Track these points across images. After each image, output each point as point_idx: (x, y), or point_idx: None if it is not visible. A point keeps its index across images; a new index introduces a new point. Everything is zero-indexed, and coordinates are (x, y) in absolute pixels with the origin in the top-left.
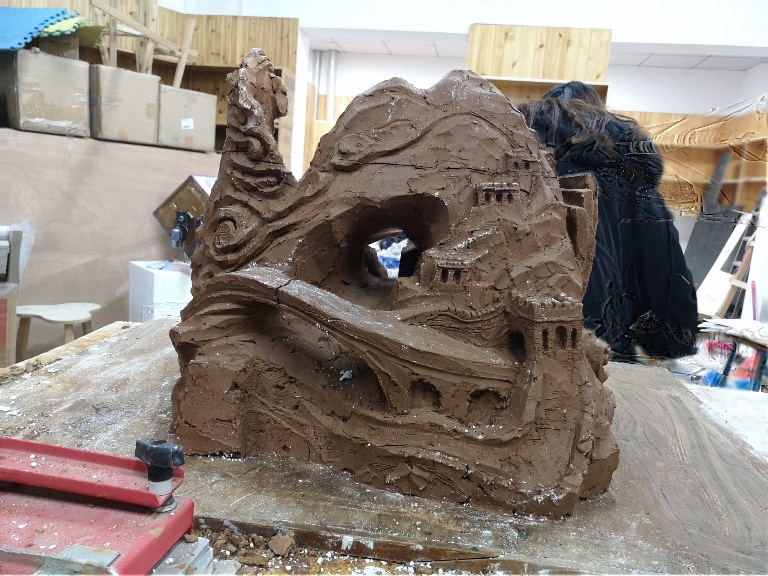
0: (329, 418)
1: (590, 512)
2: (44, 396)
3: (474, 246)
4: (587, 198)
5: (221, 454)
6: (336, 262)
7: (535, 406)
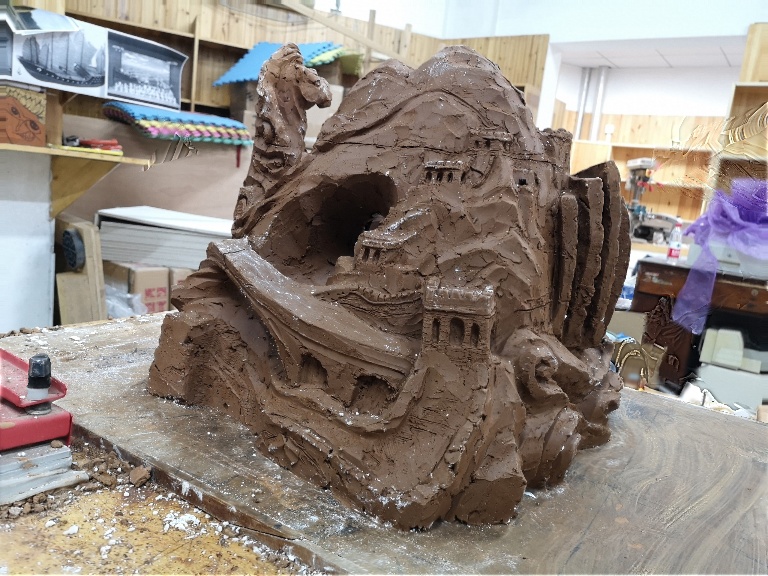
0: (261, 384)
1: (453, 536)
2: (114, 336)
3: (406, 227)
4: (592, 188)
5: (172, 398)
6: (314, 241)
7: (408, 401)
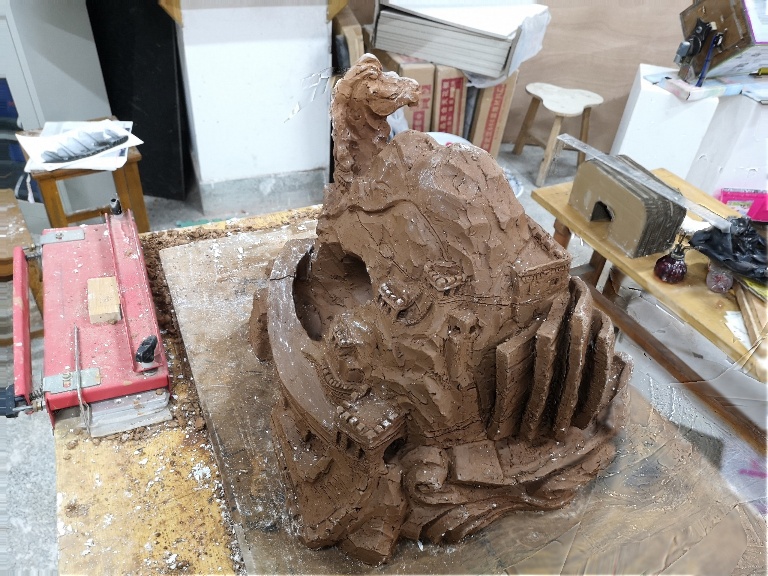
0: None
1: (329, 562)
2: (268, 249)
3: None
4: (541, 342)
5: None
6: (350, 270)
7: (318, 472)
